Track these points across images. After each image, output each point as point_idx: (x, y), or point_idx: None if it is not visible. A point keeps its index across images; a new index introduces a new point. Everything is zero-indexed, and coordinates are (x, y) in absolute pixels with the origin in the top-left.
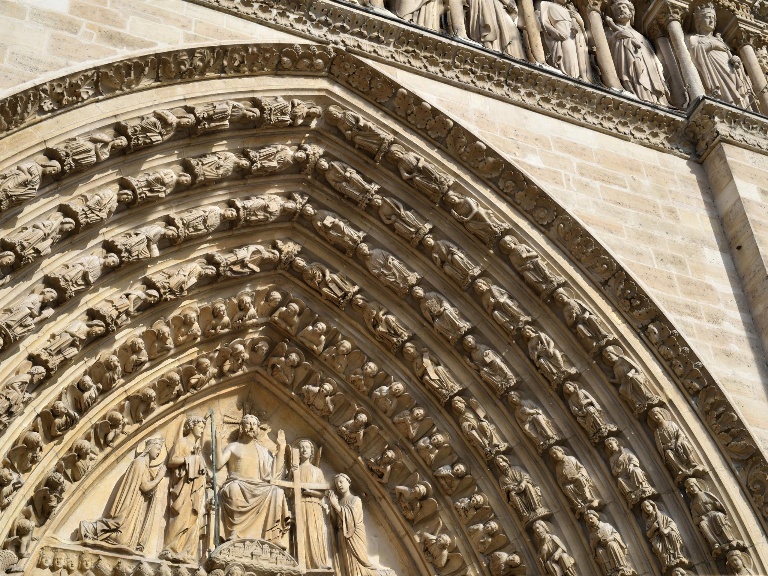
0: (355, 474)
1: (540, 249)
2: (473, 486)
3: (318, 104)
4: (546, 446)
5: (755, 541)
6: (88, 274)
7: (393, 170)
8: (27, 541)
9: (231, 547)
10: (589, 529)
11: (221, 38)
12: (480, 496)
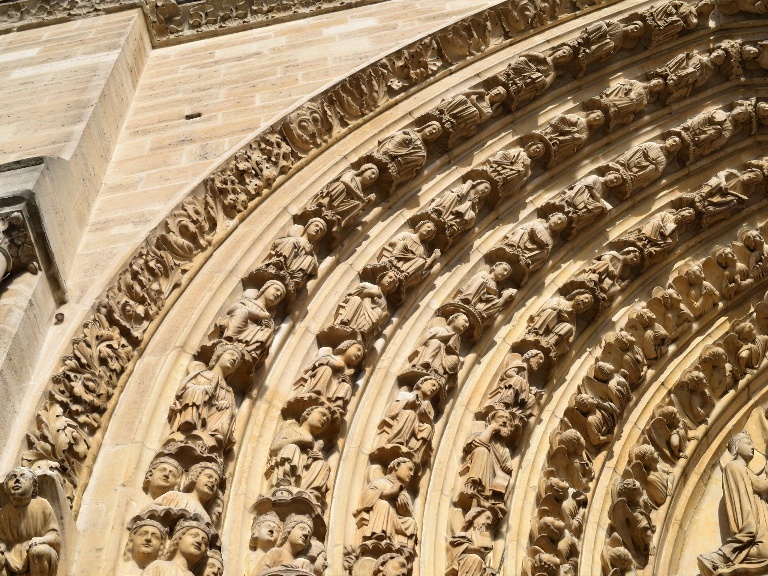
0: None
1: None
2: None
3: None
4: None
5: None
6: (535, 233)
7: None
8: None
9: None
10: None
11: None
12: None
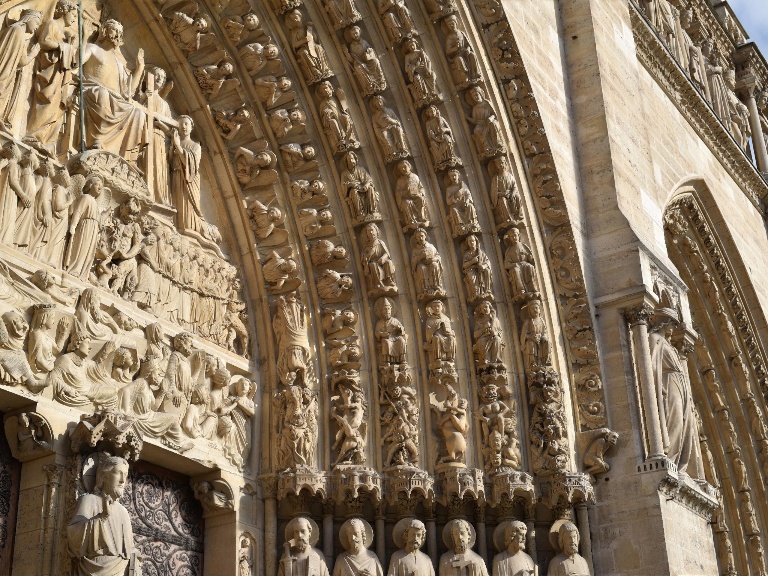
0: (195, 120)
1: None
2: (315, 171)
3: None
4: (398, 158)
5: (549, 296)
6: None
7: None
8: None
9: (97, 156)
10: (412, 244)
11: None
12: (322, 183)
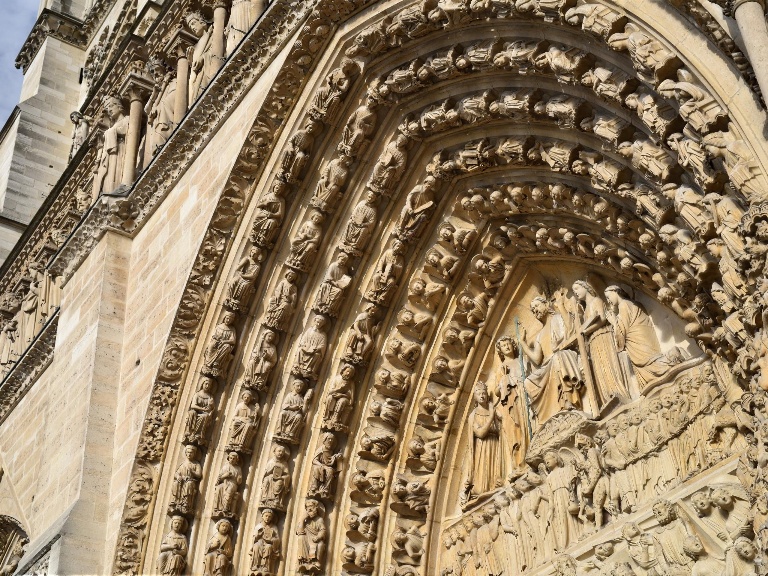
0: (623, 276)
1: None
2: None
3: None
4: (618, 152)
5: (728, 99)
6: (304, 350)
7: None
8: (410, 545)
9: None
10: None
11: None
12: (642, 236)
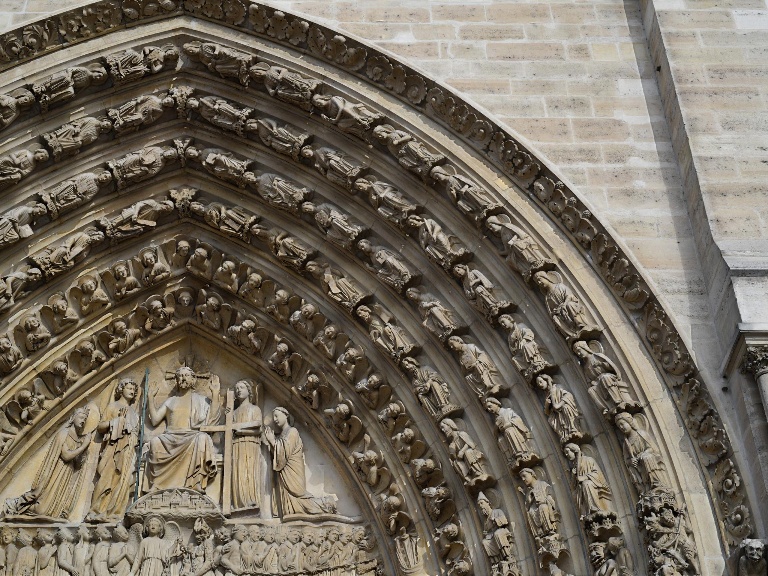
0: (296, 405)
1: (416, 131)
2: (391, 395)
3: (179, 45)
4: (444, 339)
5: (651, 398)
6: None
7: (264, 90)
8: None
9: (148, 500)
10: None
11: (53, 9)
12: (394, 404)
